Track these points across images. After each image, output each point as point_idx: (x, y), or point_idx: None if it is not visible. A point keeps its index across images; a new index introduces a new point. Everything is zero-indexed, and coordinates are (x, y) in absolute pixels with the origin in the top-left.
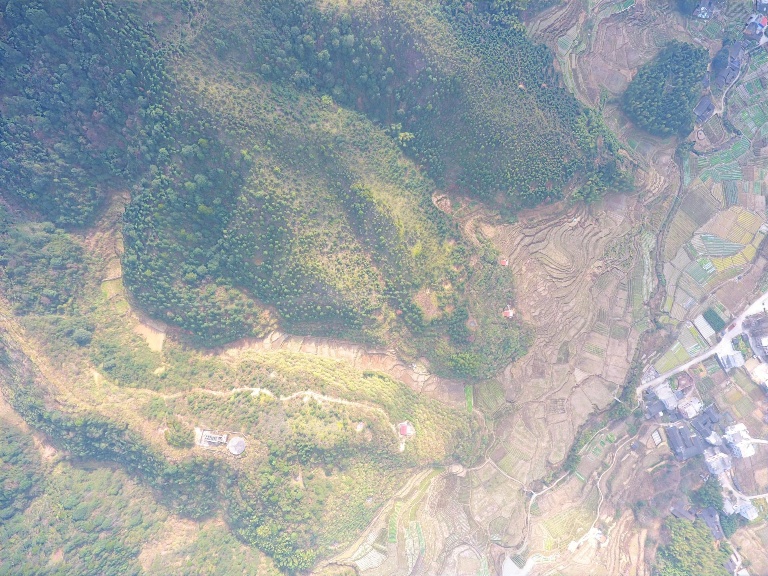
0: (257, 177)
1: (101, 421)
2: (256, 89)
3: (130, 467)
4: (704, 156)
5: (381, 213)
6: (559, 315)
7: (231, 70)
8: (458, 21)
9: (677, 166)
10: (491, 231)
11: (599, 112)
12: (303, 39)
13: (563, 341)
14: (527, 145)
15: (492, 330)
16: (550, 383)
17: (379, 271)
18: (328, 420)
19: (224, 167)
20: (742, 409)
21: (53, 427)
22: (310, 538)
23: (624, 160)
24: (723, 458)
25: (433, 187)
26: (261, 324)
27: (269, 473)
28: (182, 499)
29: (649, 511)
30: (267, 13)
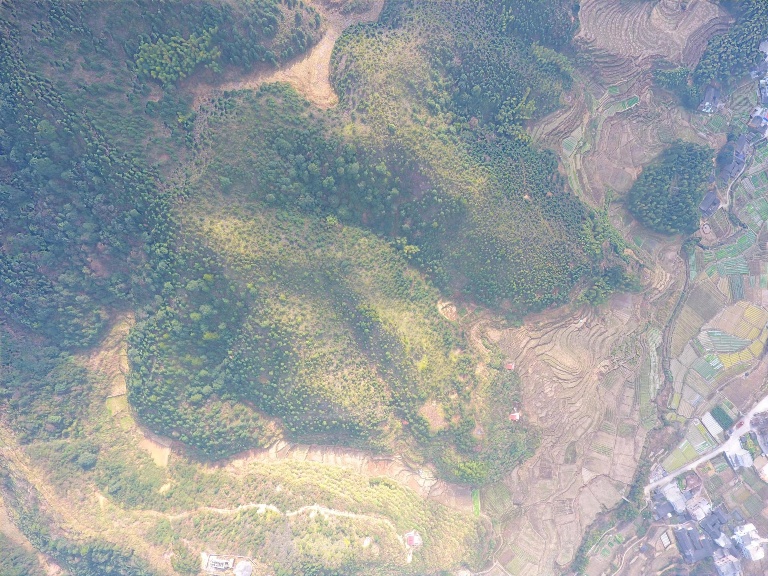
0: (262, 307)
1: (107, 548)
2: (261, 219)
3: None
4: (710, 250)
5: (387, 331)
6: (566, 415)
7: (236, 203)
8: (463, 140)
9: (683, 261)
10: (497, 335)
11: (604, 212)
12: (308, 167)
13: (570, 441)
14: (533, 257)
15: (499, 436)
16: (557, 484)
17: (385, 382)
18: (335, 537)
19: (229, 297)
20: (751, 508)
21: (58, 554)
22: None
23: (630, 261)
24: (733, 562)
25: (438, 295)
26: (267, 436)
27: None
28: None
29: None
30: (272, 144)
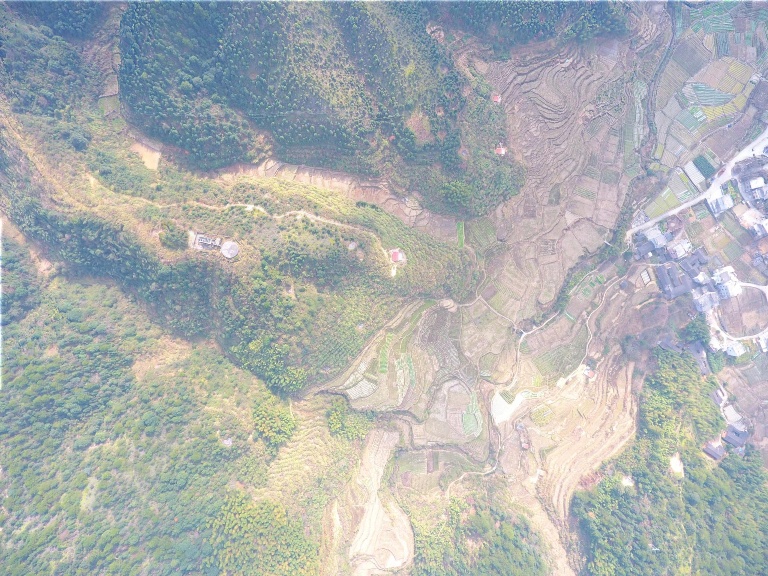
0: None
1: (96, 220)
2: None
3: (125, 282)
4: (696, 8)
5: (375, 27)
6: (551, 157)
7: None
8: None
9: (669, 17)
10: (484, 67)
11: None
12: None
13: (554, 183)
14: None
15: (484, 162)
16: (541, 224)
17: (373, 96)
18: (320, 235)
19: None
20: (730, 253)
21: (49, 227)
22: (301, 354)
23: (617, 2)
24: (711, 294)
25: (427, 17)
26: (256, 148)
27: (261, 279)
28: (176, 309)
29: (637, 342)
30: None
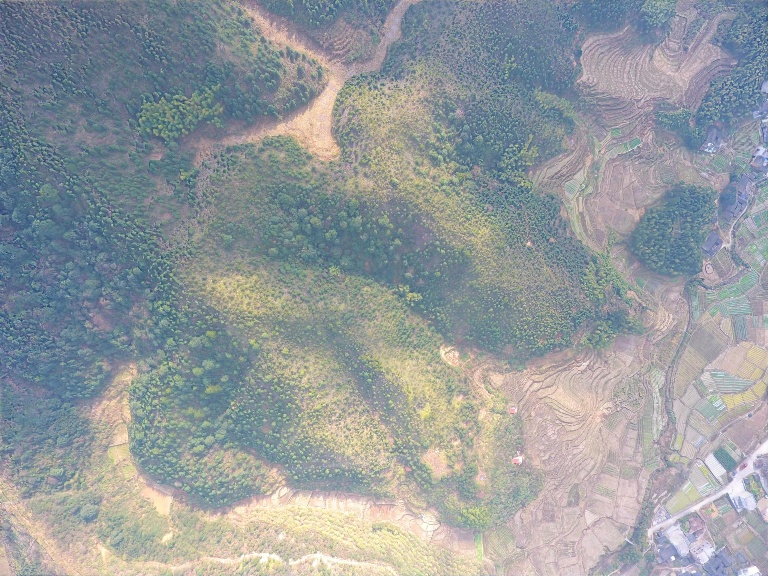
0: (265, 361)
1: None
2: (263, 273)
3: None
4: (712, 290)
5: (390, 381)
6: (569, 458)
7: (238, 259)
8: (466, 190)
9: (686, 301)
10: (500, 379)
11: (607, 255)
12: (310, 220)
13: (573, 484)
14: (536, 305)
15: (502, 481)
16: (560, 527)
17: (388, 429)
18: None
19: (232, 352)
20: (754, 550)
21: None
22: None
23: (633, 303)
24: None
25: (441, 341)
26: (269, 483)
27: None
28: None
29: None
30: (274, 198)
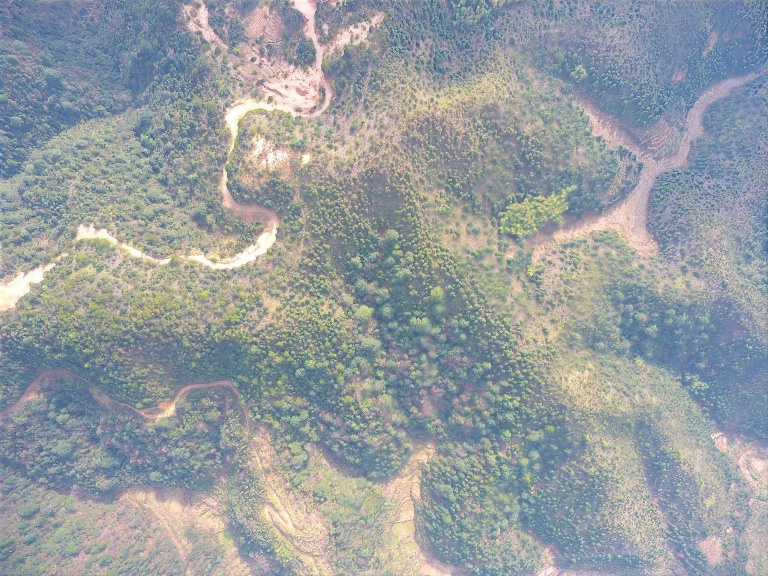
0: (590, 455)
1: None
2: (592, 367)
3: None
4: None
5: (685, 471)
6: None
7: None
8: None
9: None
10: (760, 465)
11: None
12: (635, 316)
13: None
14: None
15: (764, 569)
16: None
17: (663, 515)
18: None
19: (557, 444)
20: None
21: None
22: None
23: None
24: None
25: (713, 427)
26: (542, 563)
27: None
28: None
29: None
30: (607, 294)
